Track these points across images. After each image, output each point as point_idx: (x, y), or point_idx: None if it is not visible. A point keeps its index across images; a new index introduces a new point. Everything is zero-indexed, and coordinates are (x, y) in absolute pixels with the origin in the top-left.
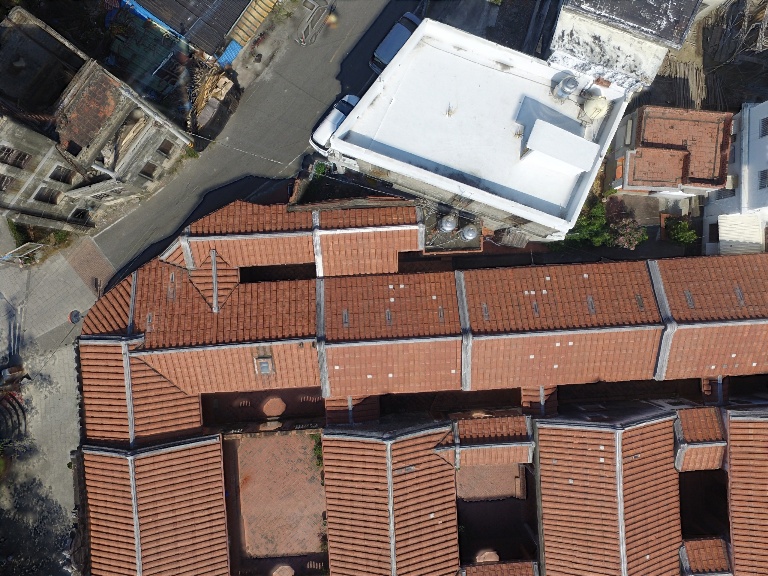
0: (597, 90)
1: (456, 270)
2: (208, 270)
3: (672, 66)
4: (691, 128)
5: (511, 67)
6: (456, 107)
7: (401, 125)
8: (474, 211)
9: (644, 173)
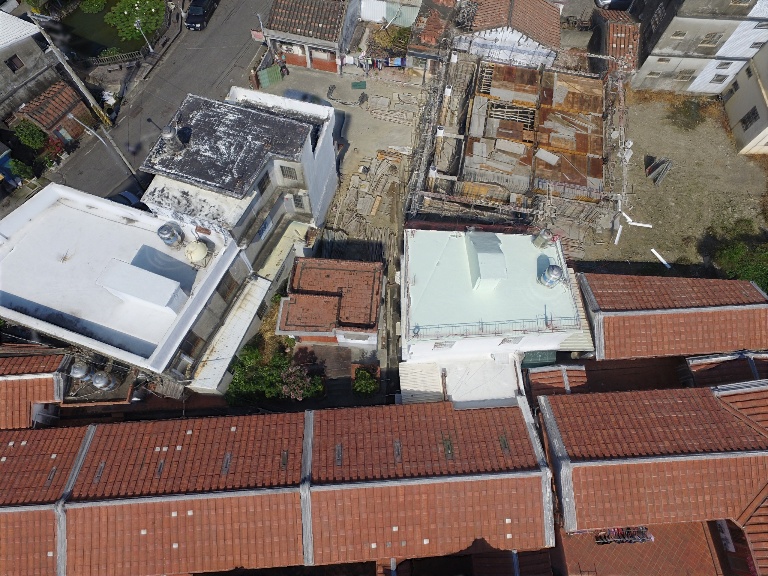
0: (205, 238)
1: (91, 424)
2: None
3: (367, 231)
4: (347, 277)
5: (136, 221)
6: (73, 254)
7: (14, 270)
8: (111, 357)
9: (297, 318)
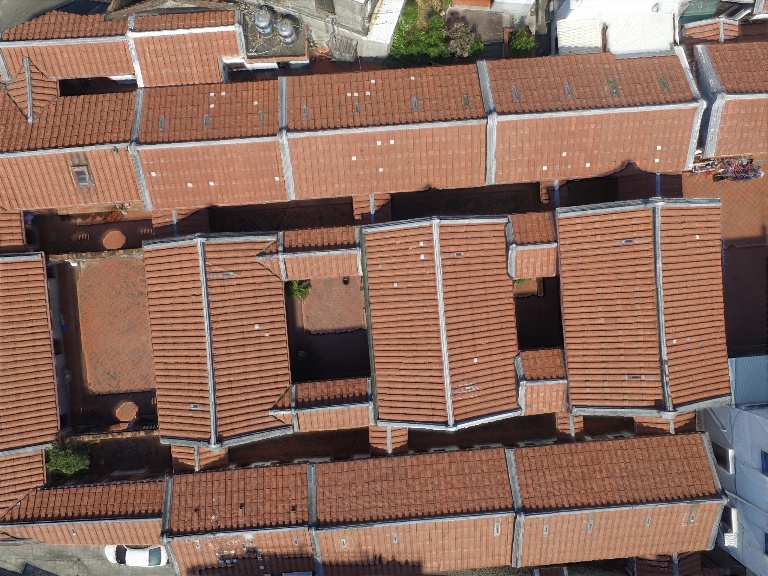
0: None
1: None
2: (23, 80)
3: None
4: None
5: None
6: None
7: None
8: (289, 7)
9: None
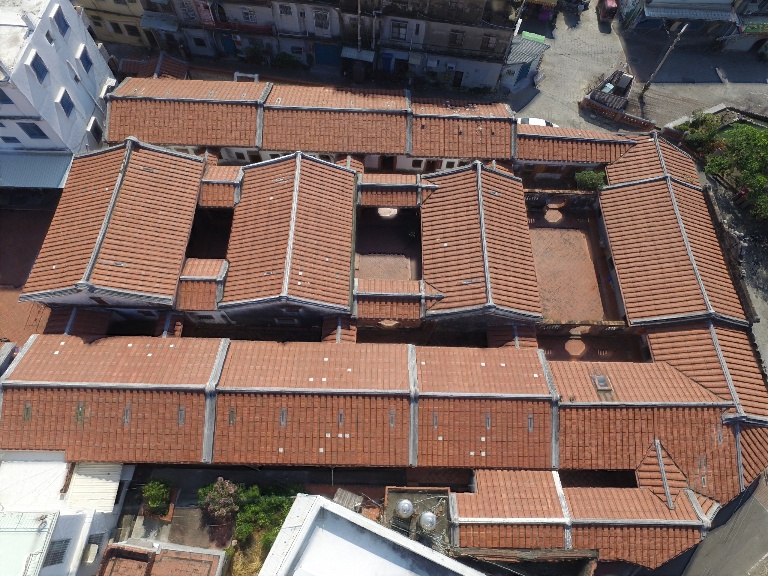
0: None
1: None
2: (672, 487)
3: None
4: None
5: None
6: None
7: None
8: None
9: (198, 571)
